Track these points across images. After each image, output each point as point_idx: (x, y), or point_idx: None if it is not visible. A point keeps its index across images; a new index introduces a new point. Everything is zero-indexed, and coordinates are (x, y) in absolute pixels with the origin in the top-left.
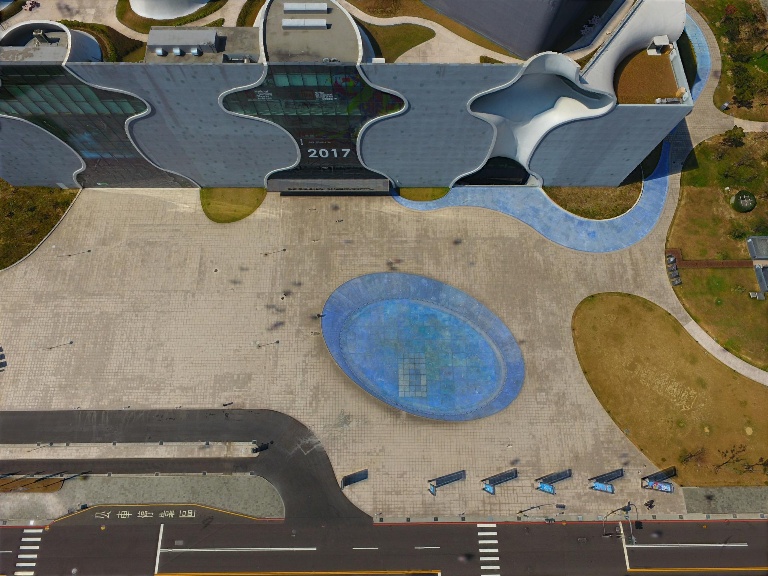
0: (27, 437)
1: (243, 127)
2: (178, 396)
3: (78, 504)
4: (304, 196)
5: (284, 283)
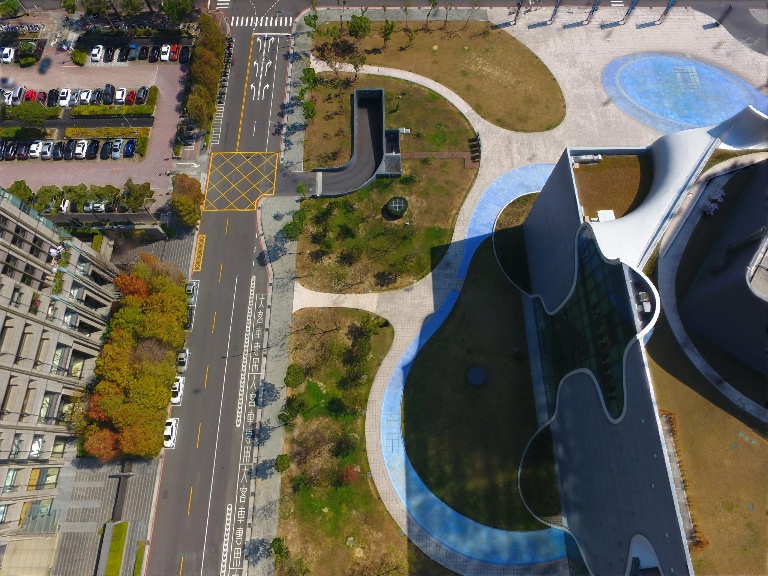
0: None
1: None
2: None
3: None
4: None
5: None
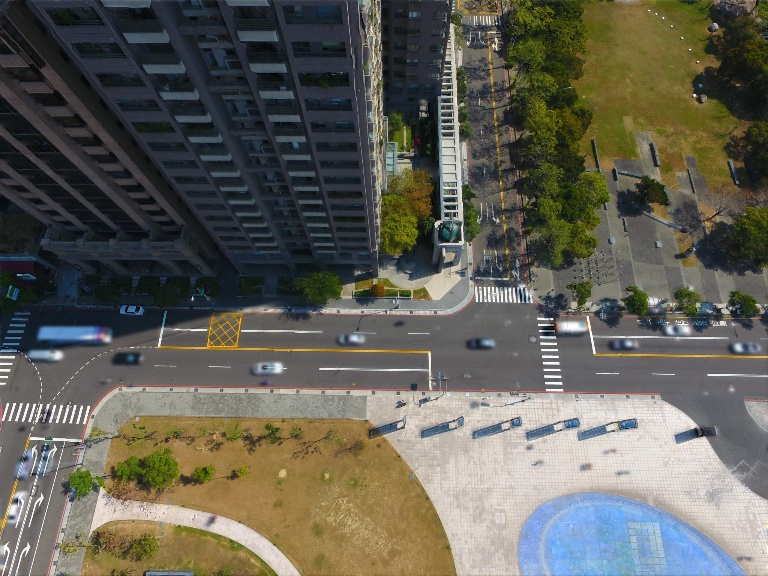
0: None
1: None
2: None
3: None
4: None
5: None
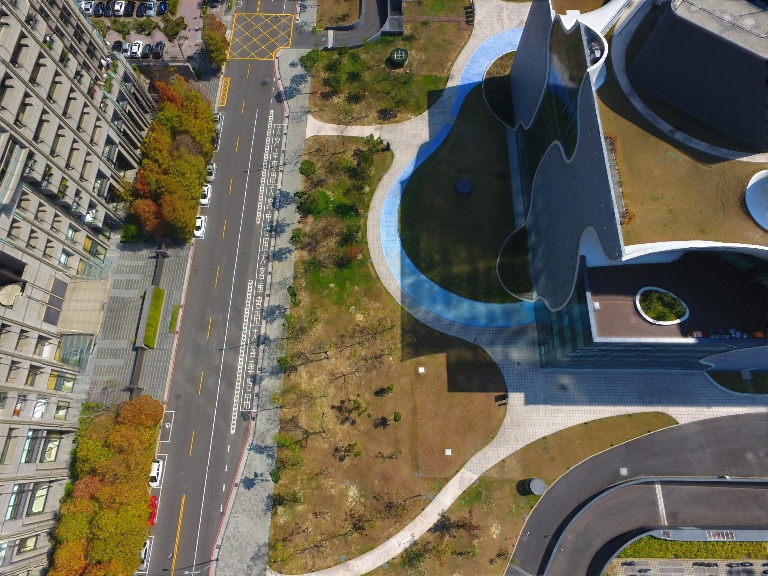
0: None
1: None
2: None
3: None
4: None
5: None
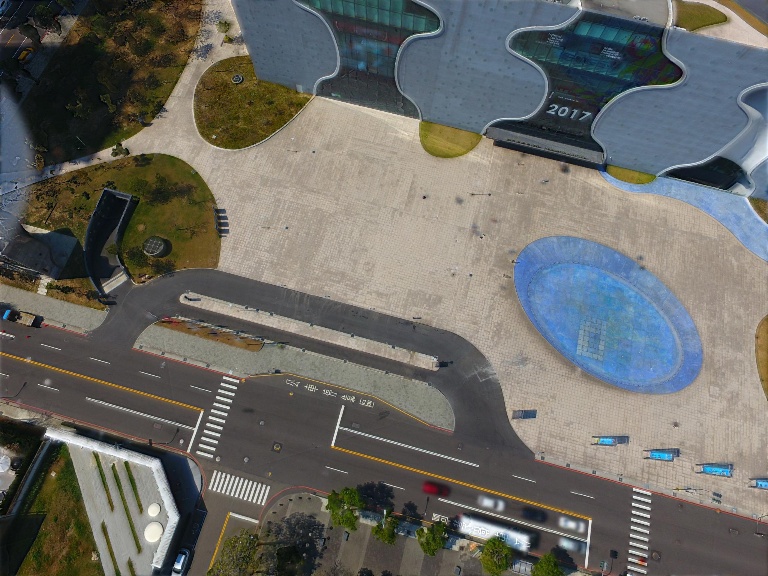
0: (238, 299)
1: (509, 67)
2: (374, 299)
3: (273, 368)
4: (515, 150)
5: (485, 224)
